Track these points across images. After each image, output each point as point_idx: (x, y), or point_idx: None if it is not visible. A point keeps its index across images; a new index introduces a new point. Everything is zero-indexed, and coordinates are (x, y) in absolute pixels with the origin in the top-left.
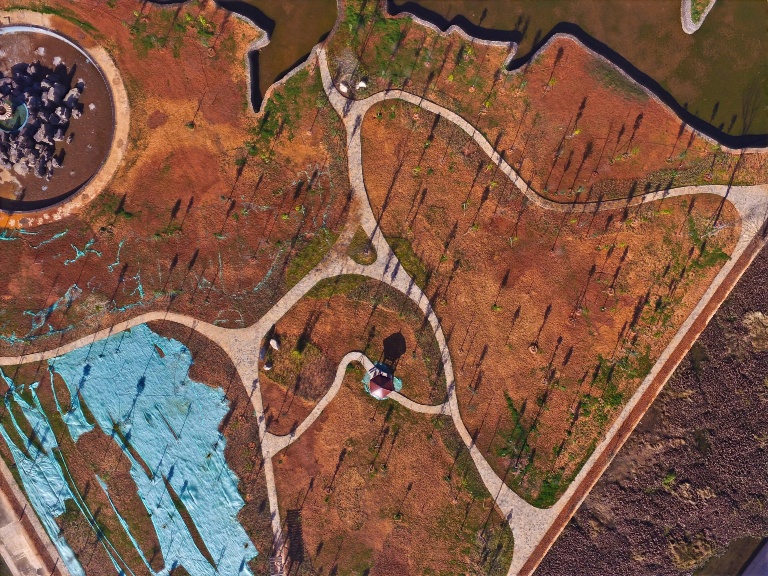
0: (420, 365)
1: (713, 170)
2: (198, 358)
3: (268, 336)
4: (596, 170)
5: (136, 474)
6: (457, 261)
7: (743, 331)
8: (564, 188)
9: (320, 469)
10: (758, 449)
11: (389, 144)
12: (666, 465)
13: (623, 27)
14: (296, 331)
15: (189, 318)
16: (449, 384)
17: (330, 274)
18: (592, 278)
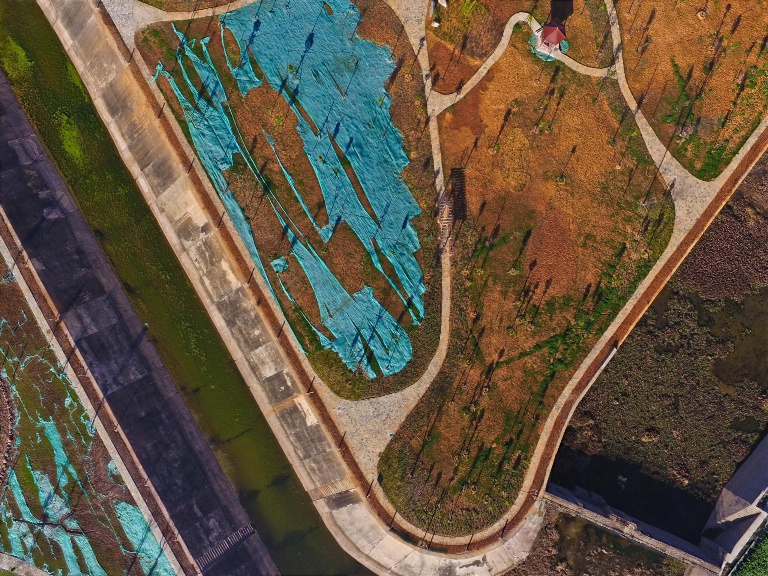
0: (587, 27)
1: None
2: (366, 15)
3: None
4: None
5: (302, 130)
6: None
7: None
8: None
9: (484, 129)
10: None
11: None
12: None
13: None
14: None
15: None
16: (616, 47)
17: None
18: None
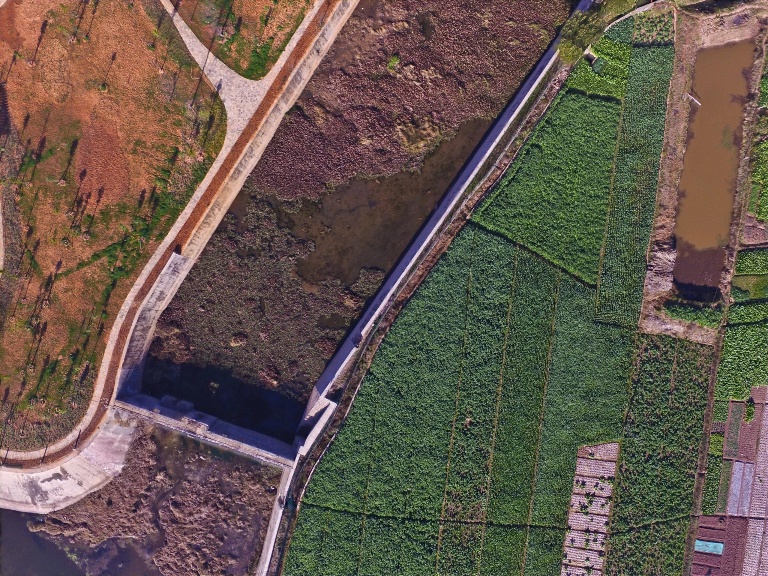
0: None
1: None
2: None
3: None
4: None
5: None
6: None
7: None
8: None
9: (22, 42)
10: (483, 28)
11: None
12: (390, 49)
13: None
14: None
15: None
16: None
17: None
18: None
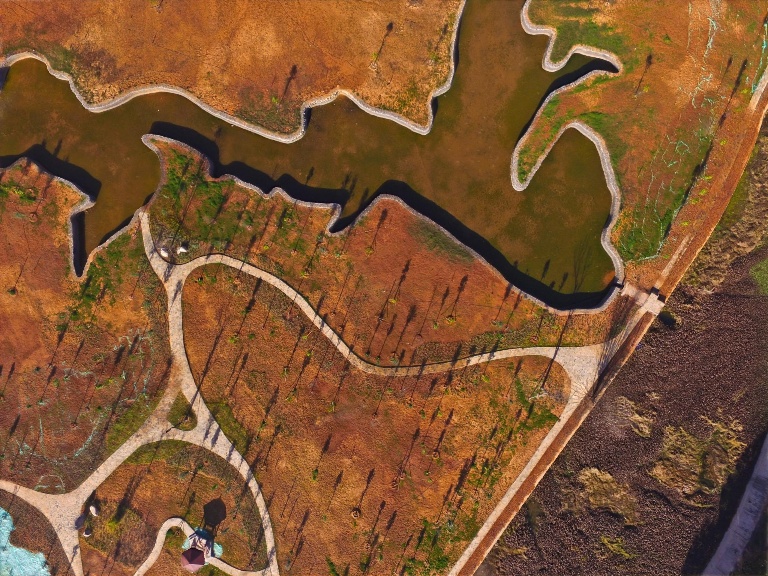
0: None
1: (540, 332)
2: (19, 524)
3: (88, 502)
4: (420, 333)
5: None
6: (278, 426)
7: (579, 487)
8: (387, 352)
9: None
10: None
11: (210, 308)
12: None
13: (452, 184)
14: (117, 497)
15: (10, 484)
16: (270, 550)
17: (150, 440)
18: (416, 442)
